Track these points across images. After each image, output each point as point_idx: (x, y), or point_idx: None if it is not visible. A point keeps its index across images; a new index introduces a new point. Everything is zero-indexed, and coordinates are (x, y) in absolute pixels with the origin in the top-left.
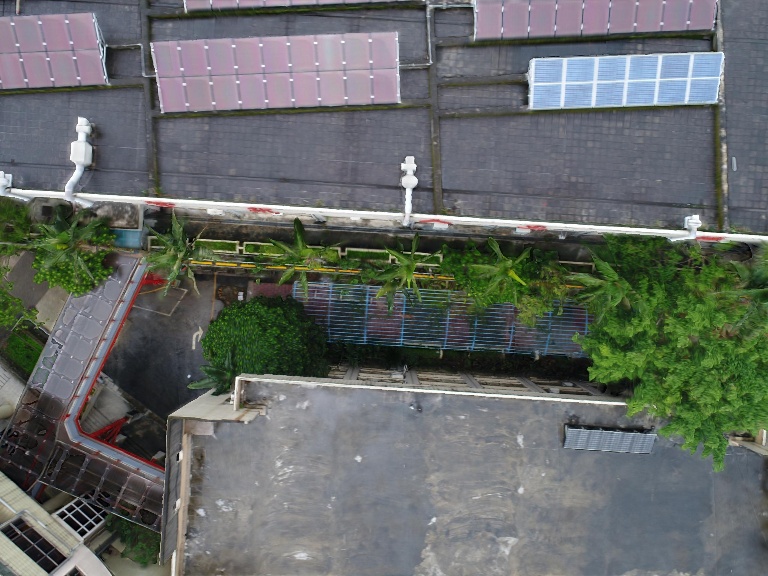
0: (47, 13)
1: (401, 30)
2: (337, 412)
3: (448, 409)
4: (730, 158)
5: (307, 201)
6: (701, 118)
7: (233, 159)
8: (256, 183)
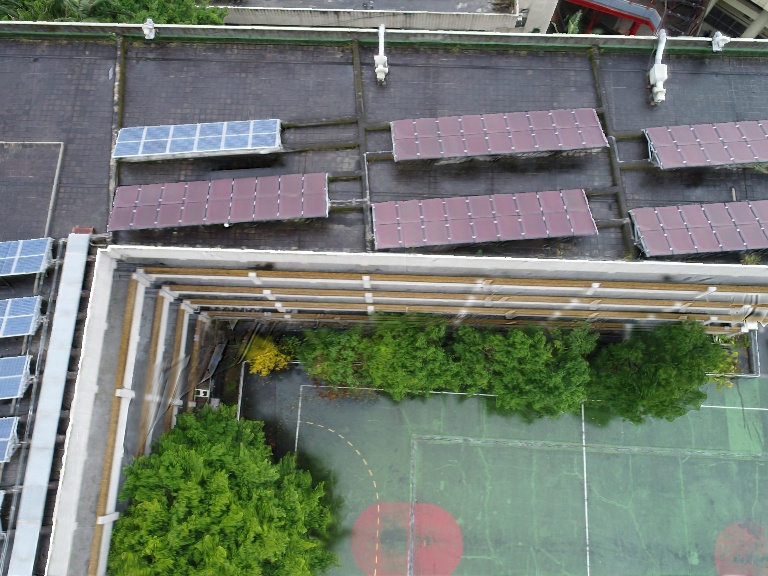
0: (707, 191)
1: (392, 186)
2: (433, 2)
3: (342, 6)
4: (111, 95)
5: (466, 53)
6: (133, 124)
7: (530, 82)
8: (509, 65)
